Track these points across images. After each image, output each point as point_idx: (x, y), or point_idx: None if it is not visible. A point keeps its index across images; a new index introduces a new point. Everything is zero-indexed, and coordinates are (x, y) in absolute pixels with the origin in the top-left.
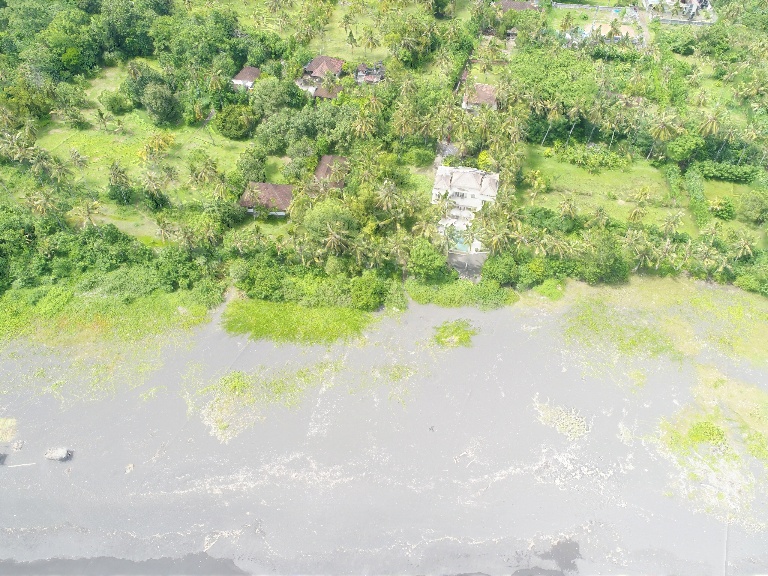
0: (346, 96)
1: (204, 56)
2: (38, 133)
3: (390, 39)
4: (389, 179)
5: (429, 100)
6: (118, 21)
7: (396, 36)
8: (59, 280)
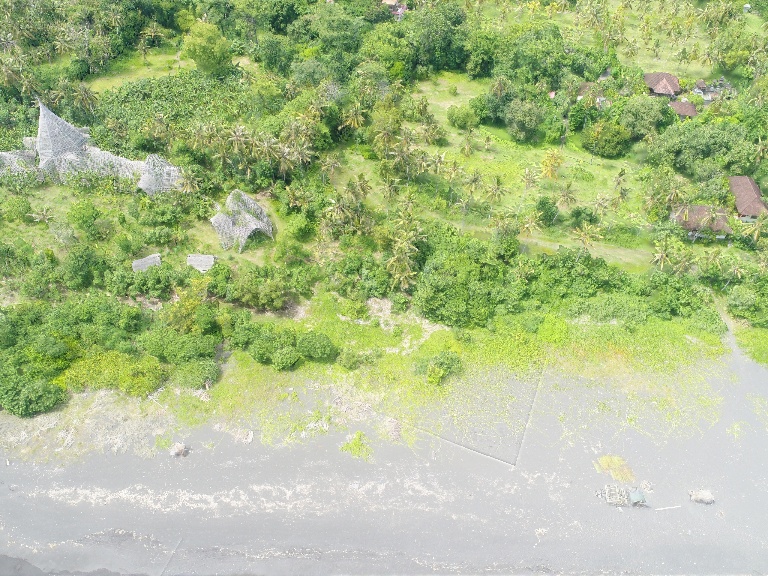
0: (712, 114)
1: (551, 72)
2: None
3: (737, 56)
4: None
5: None
6: (437, 34)
7: (746, 53)
8: (542, 306)
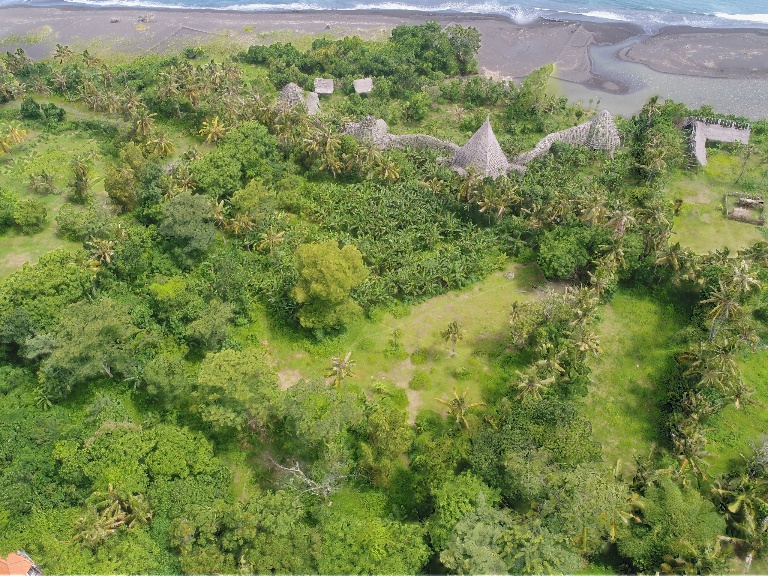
0: None
1: None
2: None
3: None
4: None
5: None
6: None
7: None
8: None
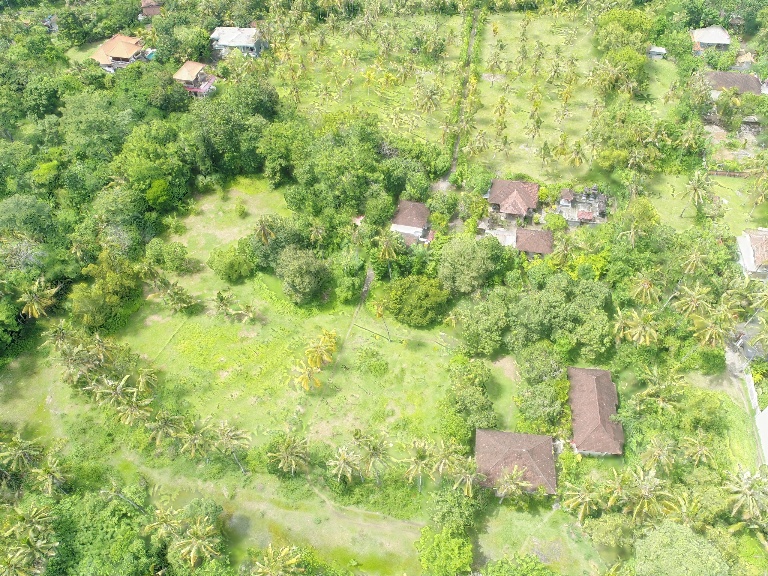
0: (568, 253)
1: (352, 194)
2: (130, 324)
3: (612, 157)
4: (701, 426)
5: (708, 267)
6: (217, 136)
7: (623, 154)
8: None
